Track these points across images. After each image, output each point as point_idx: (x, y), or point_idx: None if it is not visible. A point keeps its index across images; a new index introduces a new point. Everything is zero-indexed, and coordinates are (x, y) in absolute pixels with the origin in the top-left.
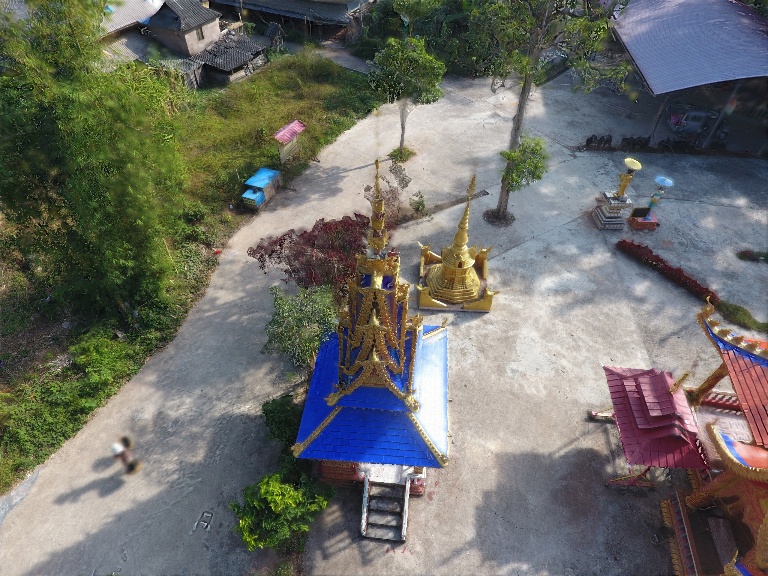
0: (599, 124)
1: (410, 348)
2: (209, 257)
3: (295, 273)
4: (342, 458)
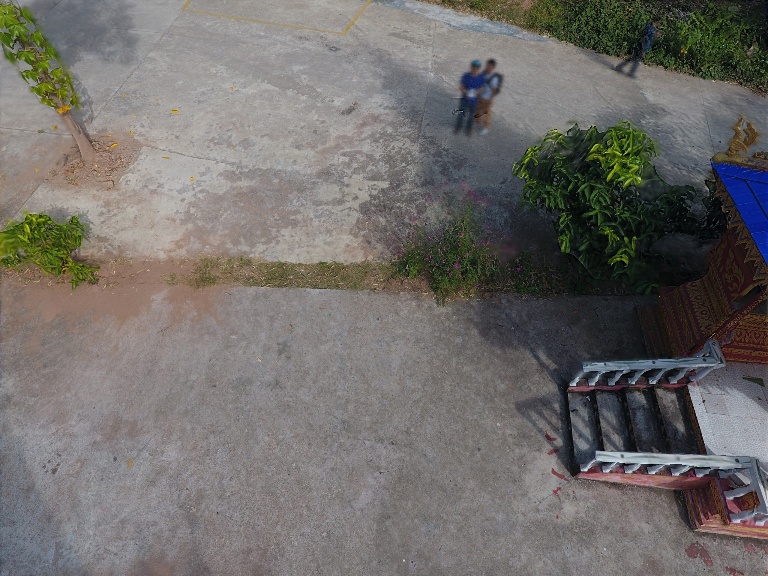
0: None
1: None
2: None
3: None
4: (759, 236)
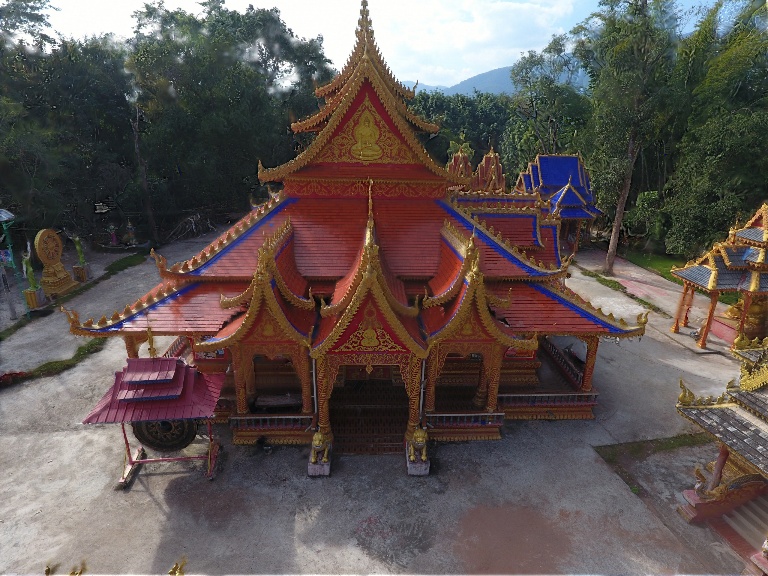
0: None
1: None
2: None
3: None
4: None
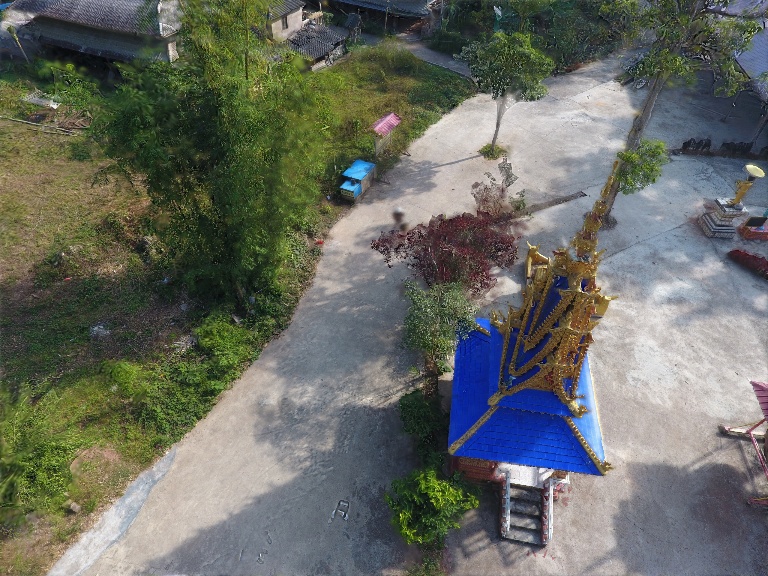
0: (692, 127)
1: (579, 352)
2: (312, 247)
3: (425, 268)
4: (498, 459)
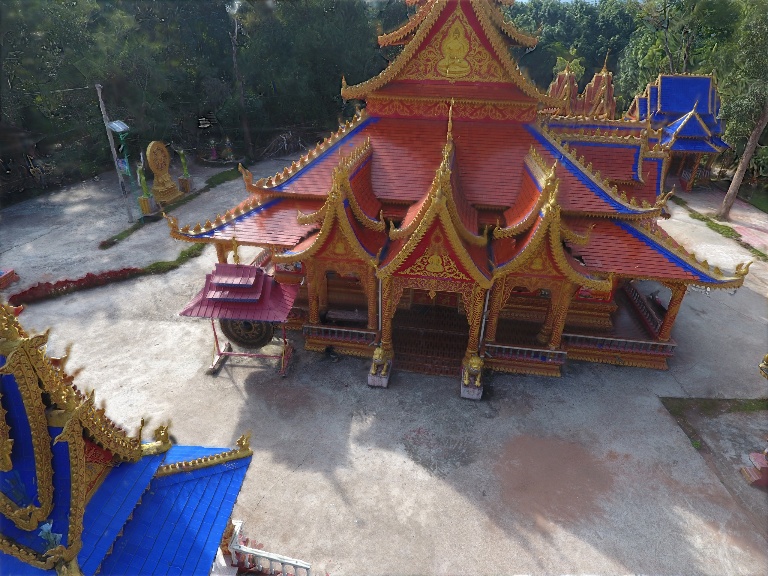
0: None
1: None
2: None
3: None
4: None
